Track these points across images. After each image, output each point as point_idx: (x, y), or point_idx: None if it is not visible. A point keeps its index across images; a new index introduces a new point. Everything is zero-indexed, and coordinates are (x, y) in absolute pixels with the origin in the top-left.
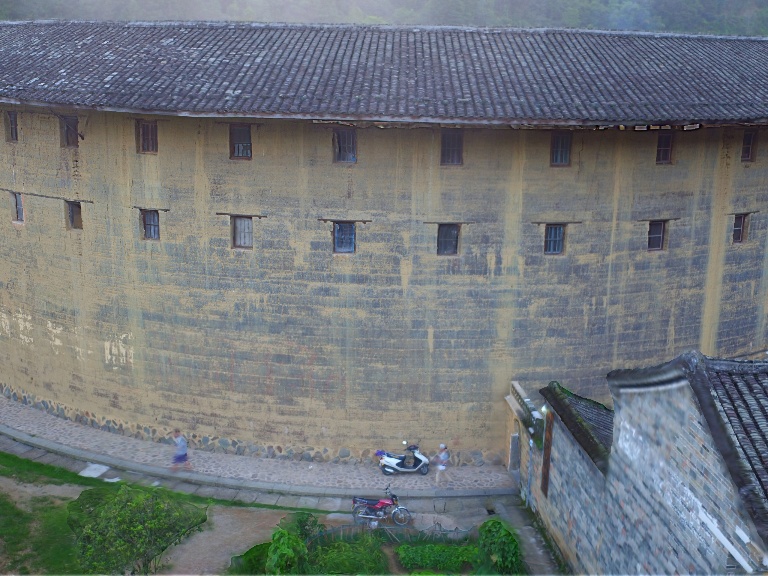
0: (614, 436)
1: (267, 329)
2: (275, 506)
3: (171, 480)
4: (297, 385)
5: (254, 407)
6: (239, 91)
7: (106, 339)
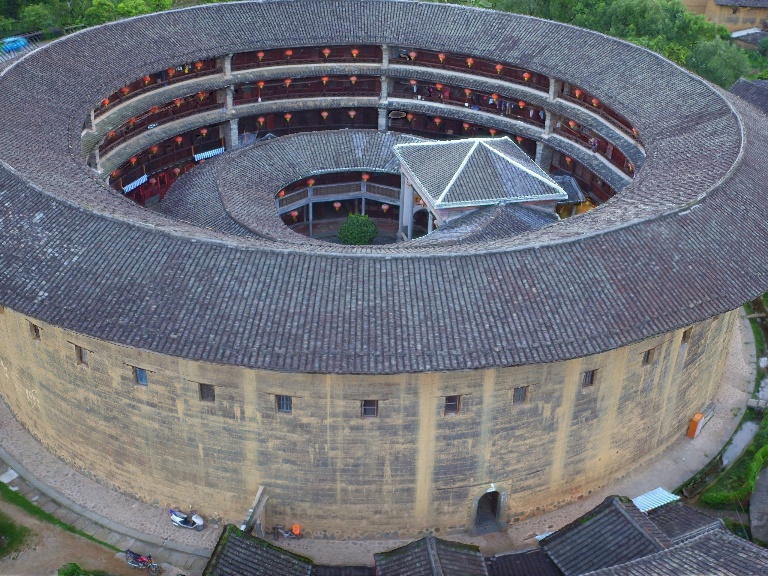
0: None
1: (103, 418)
2: (91, 537)
3: (46, 497)
4: (124, 455)
5: (102, 459)
6: (47, 294)
7: (26, 387)
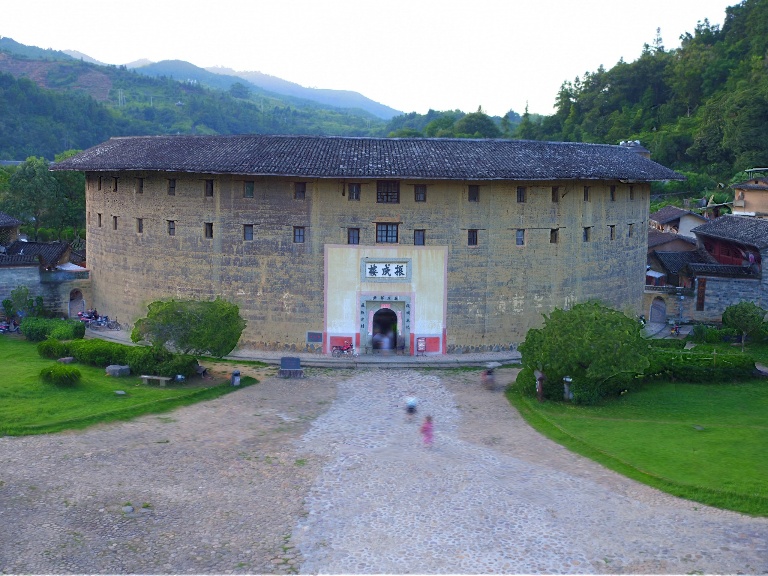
0: (765, 266)
1: None
2: None
3: None
4: None
5: None
6: None
7: (566, 296)
